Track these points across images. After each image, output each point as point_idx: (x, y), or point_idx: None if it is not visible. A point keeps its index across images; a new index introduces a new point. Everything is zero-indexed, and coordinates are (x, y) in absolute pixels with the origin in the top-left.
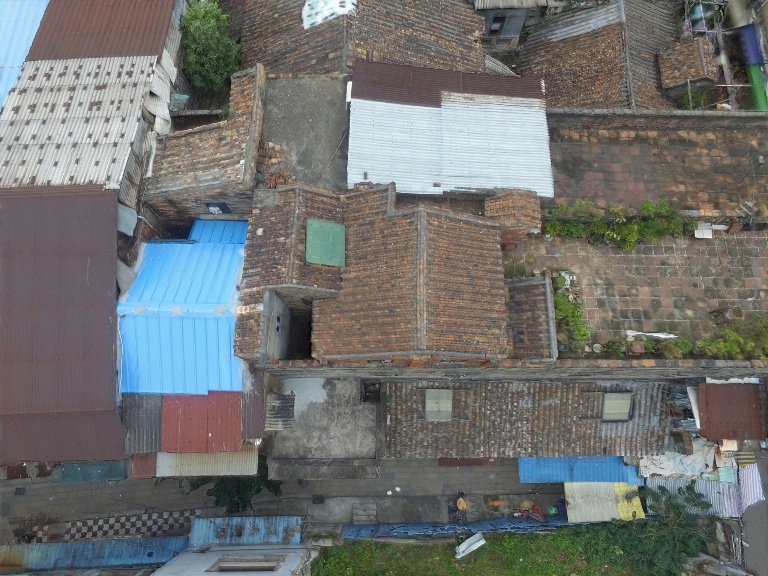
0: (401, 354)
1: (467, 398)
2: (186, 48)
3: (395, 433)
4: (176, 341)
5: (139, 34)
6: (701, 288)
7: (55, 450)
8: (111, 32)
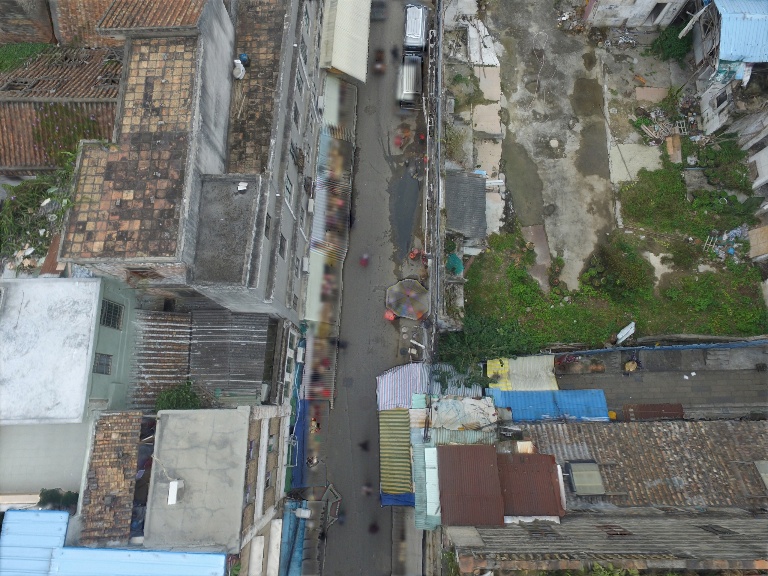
0: None
1: (746, 487)
2: None
3: None
4: None
5: None
6: None
7: None
8: None
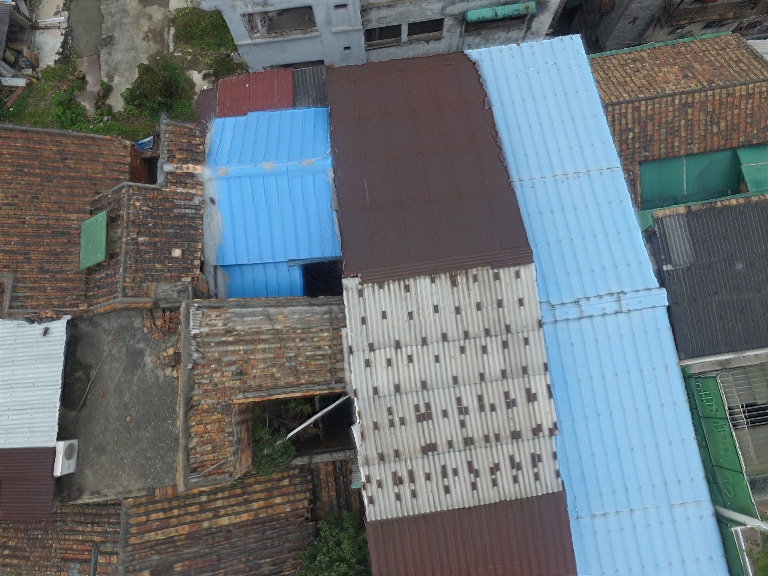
0: (8, 126)
1: None
2: (364, 571)
3: None
4: (273, 145)
5: (413, 568)
6: None
7: (393, 62)
8: (459, 570)
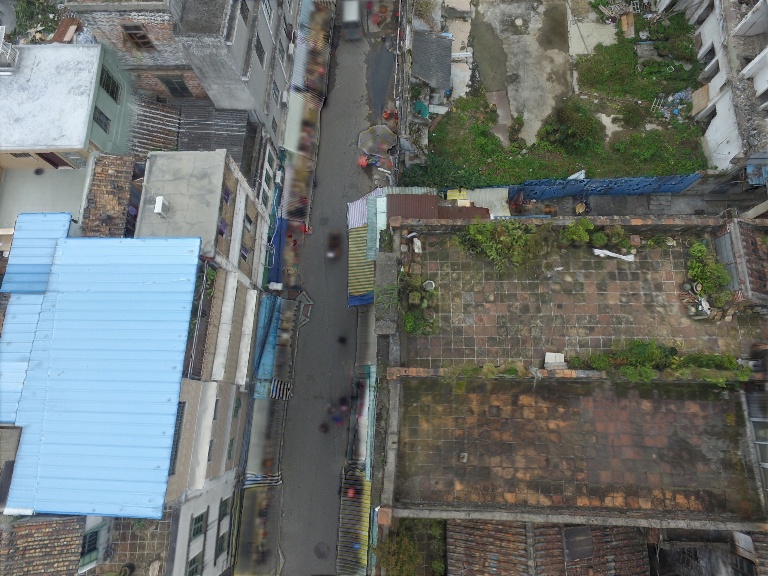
0: None
1: None
2: None
3: None
4: None
5: None
6: (555, 303)
7: None
8: None
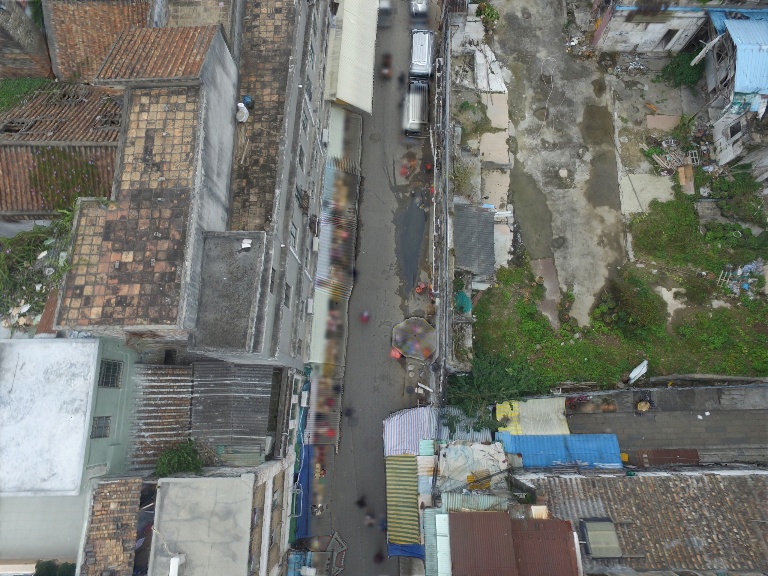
0: None
1: None
2: None
3: None
4: None
5: None
6: None
7: None
8: None
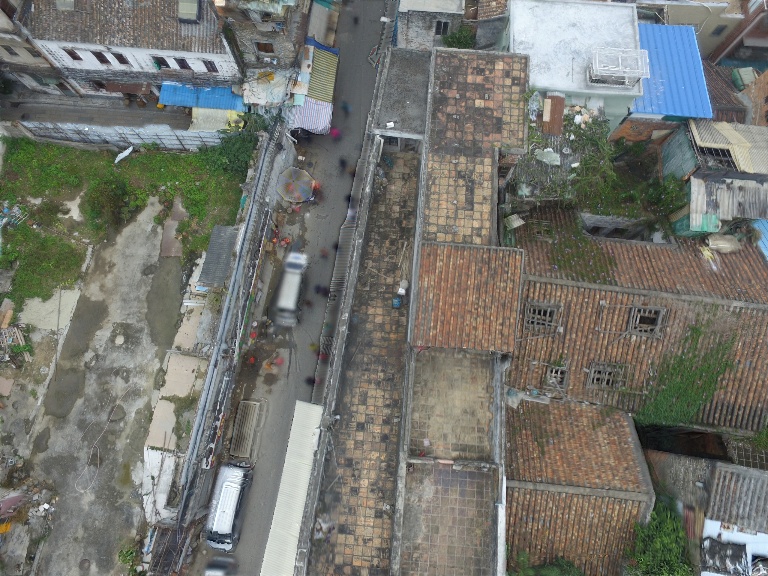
0: None
1: None
2: None
3: (38, 19)
4: None
5: None
6: None
7: None
8: None
